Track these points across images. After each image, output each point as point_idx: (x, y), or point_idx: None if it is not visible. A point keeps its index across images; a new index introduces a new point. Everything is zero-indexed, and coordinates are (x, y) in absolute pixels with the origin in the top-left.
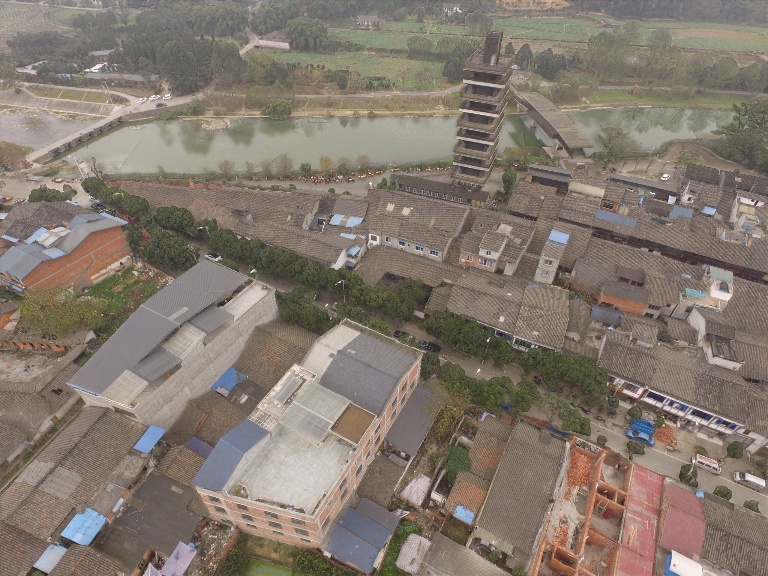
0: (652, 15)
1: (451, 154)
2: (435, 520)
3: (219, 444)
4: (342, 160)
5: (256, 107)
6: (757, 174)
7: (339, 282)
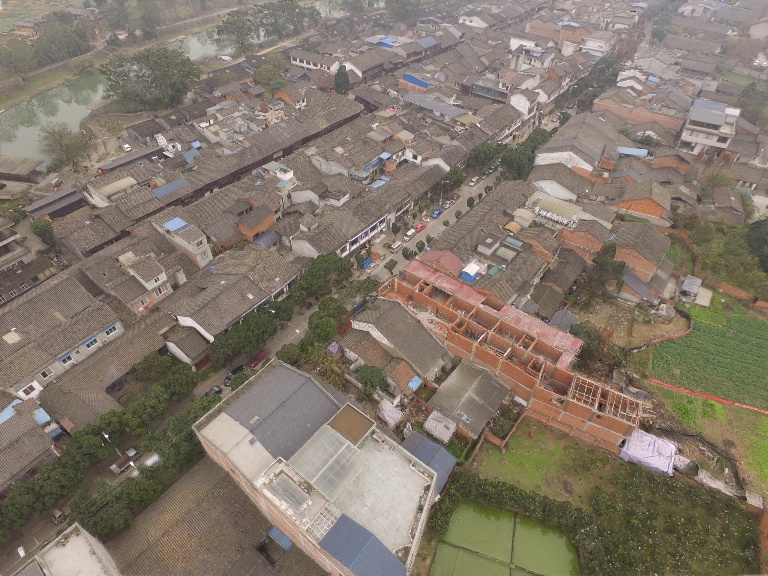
0: None
1: None
2: (413, 408)
3: (355, 569)
4: None
5: None
6: (165, 111)
7: (106, 436)
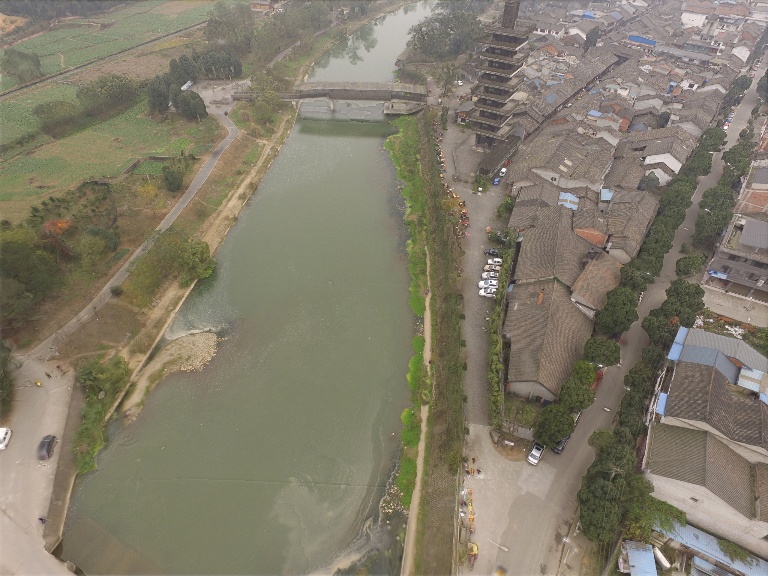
0: (109, 5)
1: (380, 155)
2: None
3: None
4: (377, 219)
5: (156, 290)
6: None
7: None
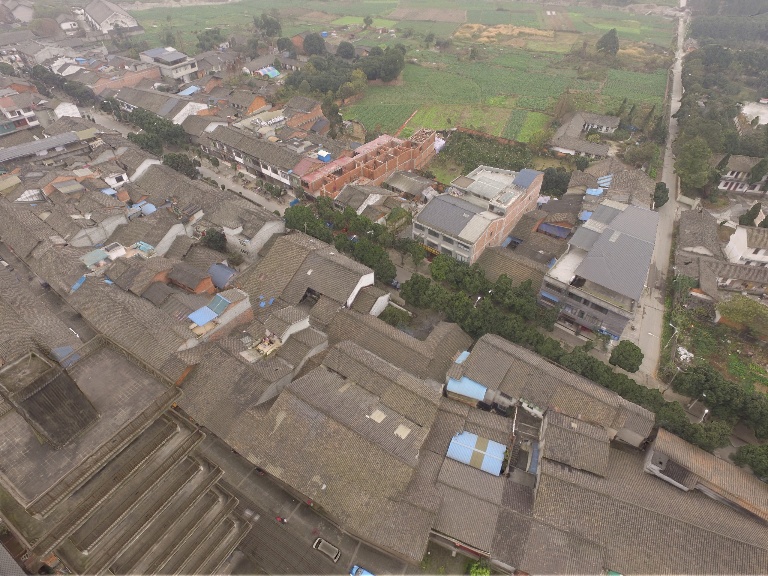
0: None
1: None
2: None
3: None
4: None
5: None
6: None
7: None
